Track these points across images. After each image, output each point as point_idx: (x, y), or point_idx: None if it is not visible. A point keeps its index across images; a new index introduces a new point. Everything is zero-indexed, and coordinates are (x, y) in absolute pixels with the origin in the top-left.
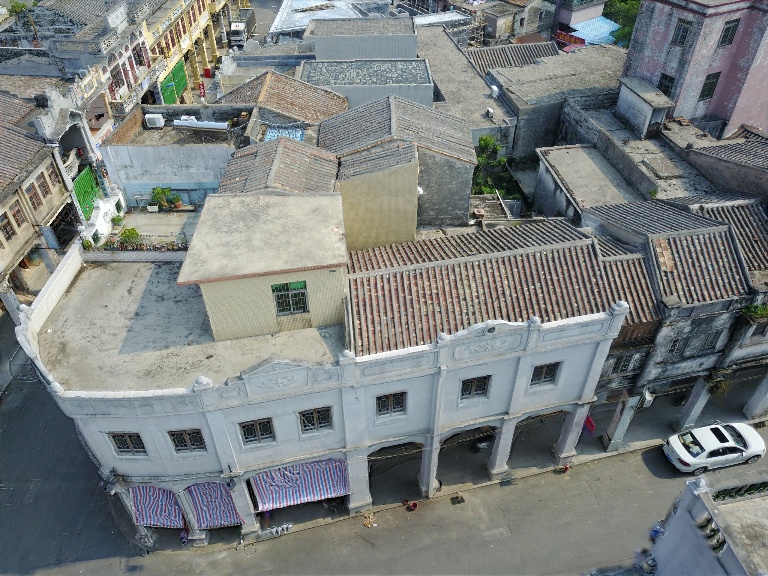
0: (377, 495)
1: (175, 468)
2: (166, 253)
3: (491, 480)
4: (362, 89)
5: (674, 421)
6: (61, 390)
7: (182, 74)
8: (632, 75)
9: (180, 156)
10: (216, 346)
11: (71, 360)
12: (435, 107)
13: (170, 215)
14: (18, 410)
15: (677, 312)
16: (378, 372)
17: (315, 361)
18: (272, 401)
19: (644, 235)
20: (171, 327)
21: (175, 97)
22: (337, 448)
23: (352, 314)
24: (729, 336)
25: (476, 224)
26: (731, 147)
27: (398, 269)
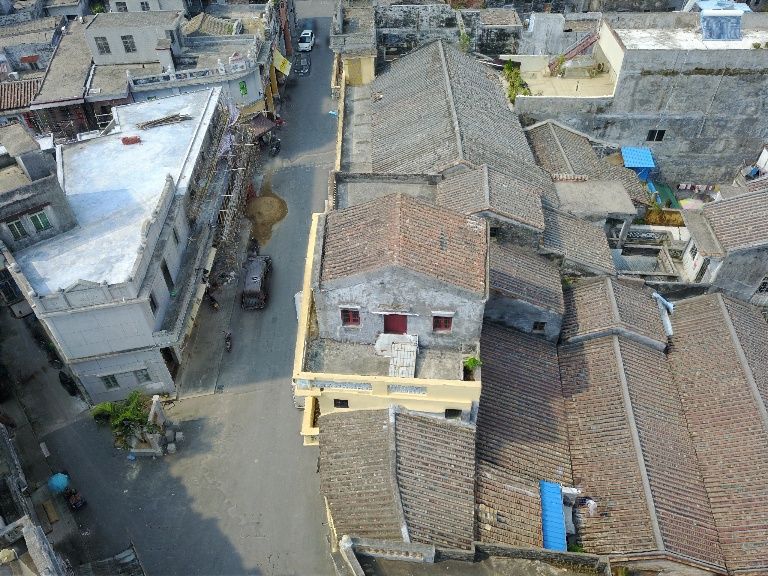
0: None
1: None
2: None
3: None
4: None
5: None
6: None
7: None
8: None
9: None
10: None
11: None
12: None
13: None
14: None
15: None
16: None
17: None
18: None
19: None
20: None
21: None
22: None
23: None
24: None
25: None
26: None
27: None
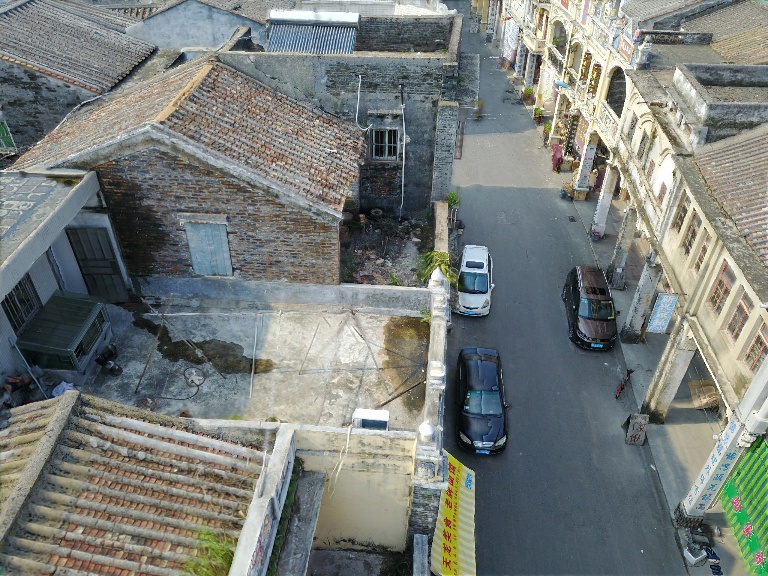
0: None
1: None
2: None
3: None
4: None
5: None
6: None
7: None
8: None
9: None
10: None
11: None
12: None
13: None
14: (570, 270)
15: None
16: None
17: None
18: None
19: None
20: None
21: None
22: None
23: None
24: None
25: None
26: None
27: None
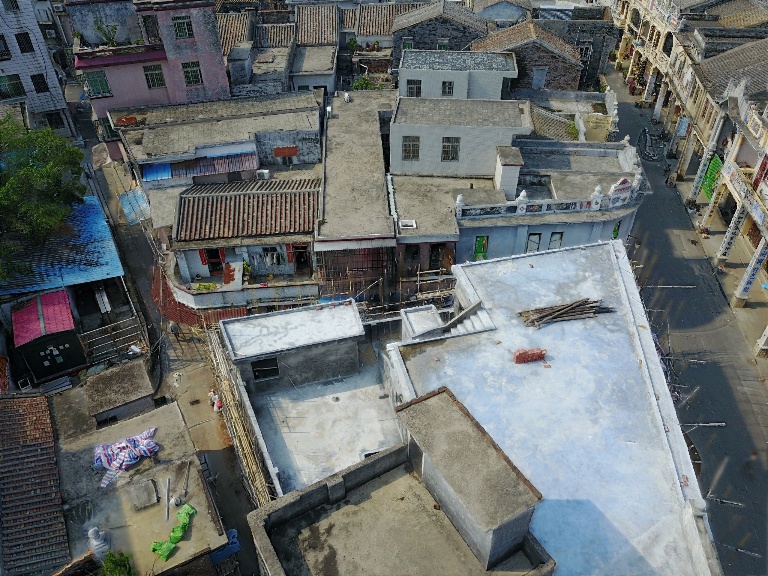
0: None
1: None
2: None
3: None
4: None
5: None
6: None
7: None
8: None
9: None
10: None
11: None
12: None
13: None
14: None
15: None
16: None
17: None
18: None
19: None
20: None
21: None
22: None
23: None
24: None
25: None
26: None
27: None
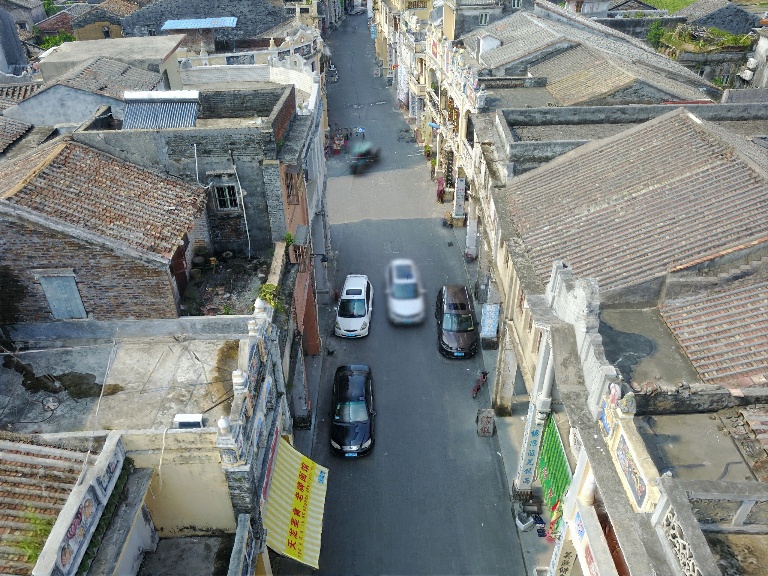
0: None
1: None
2: None
3: None
4: None
5: None
6: None
7: None
8: None
9: None
10: None
11: None
12: None
13: None
14: None
15: None
16: None
17: None
18: None
19: None
20: None
21: None
22: None
23: None
24: None
25: None
26: None
27: None
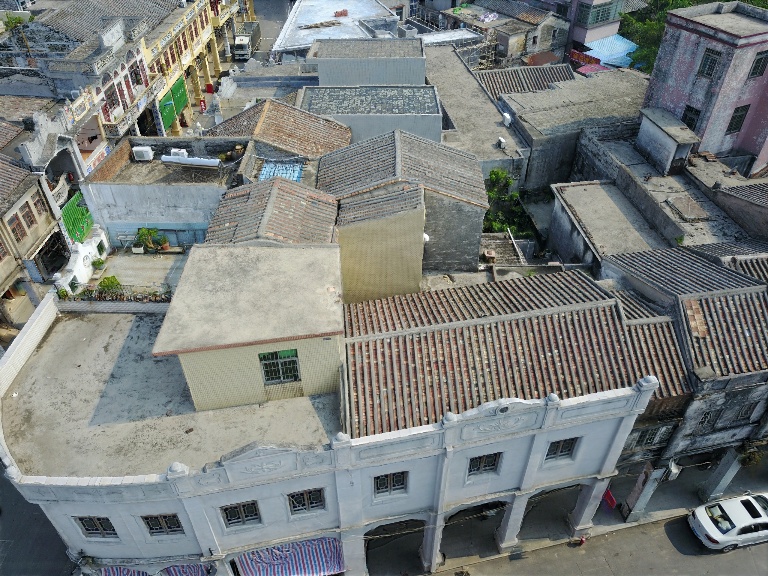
0: (375, 568)
1: (150, 551)
2: (148, 304)
3: (499, 553)
4: (366, 119)
5: (700, 489)
6: (18, 475)
7: (182, 91)
8: (654, 105)
9: (167, 196)
10: (197, 417)
11: (36, 432)
12: (444, 136)
13: (156, 257)
14: None
15: (711, 385)
16: (376, 454)
17: (306, 438)
18: (257, 484)
19: (673, 295)
20: (149, 393)
21: (174, 115)
22: (330, 528)
23: (348, 385)
24: (766, 407)
25: (486, 269)
26: (762, 188)
27: (400, 333)
